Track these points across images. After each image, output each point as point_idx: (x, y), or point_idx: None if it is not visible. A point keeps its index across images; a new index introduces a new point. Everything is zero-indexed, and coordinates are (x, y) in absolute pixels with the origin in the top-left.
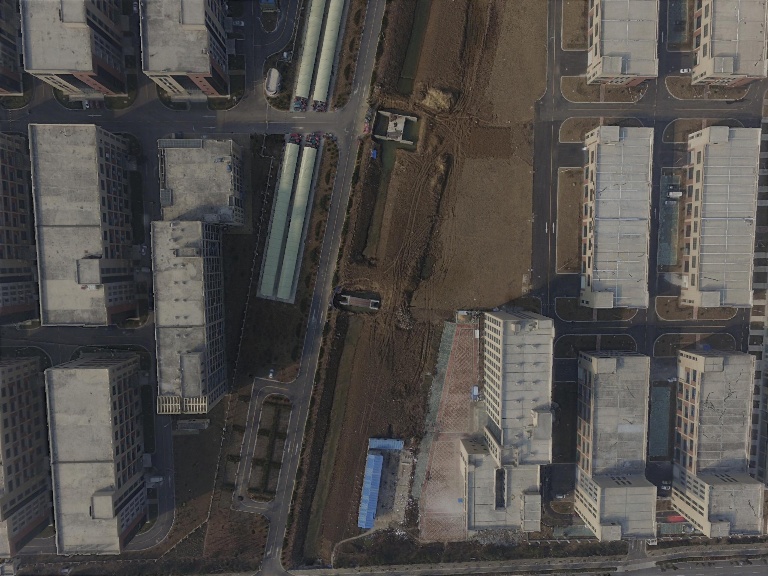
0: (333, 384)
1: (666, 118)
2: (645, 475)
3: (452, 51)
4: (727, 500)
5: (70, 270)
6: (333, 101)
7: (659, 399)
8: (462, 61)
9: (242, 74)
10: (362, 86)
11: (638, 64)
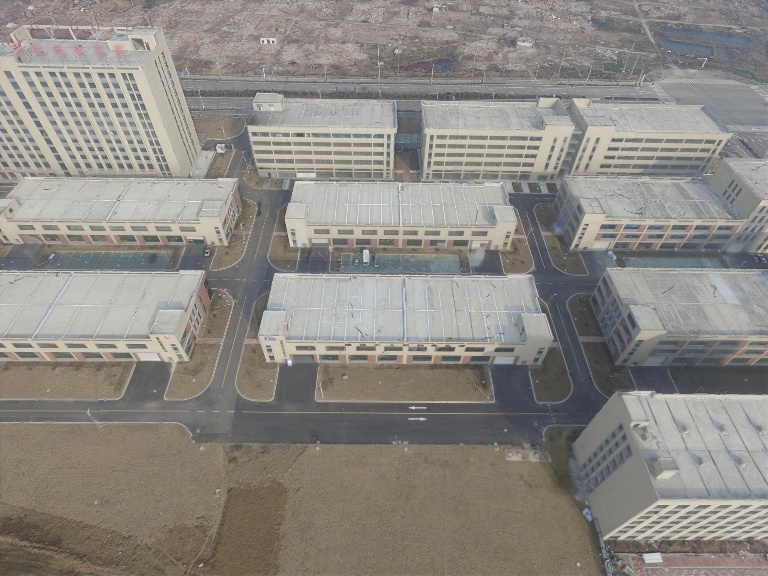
0: None
1: (264, 269)
2: None
3: None
4: (766, 187)
5: None
6: None
7: None
8: None
9: None
10: None
11: (179, 293)
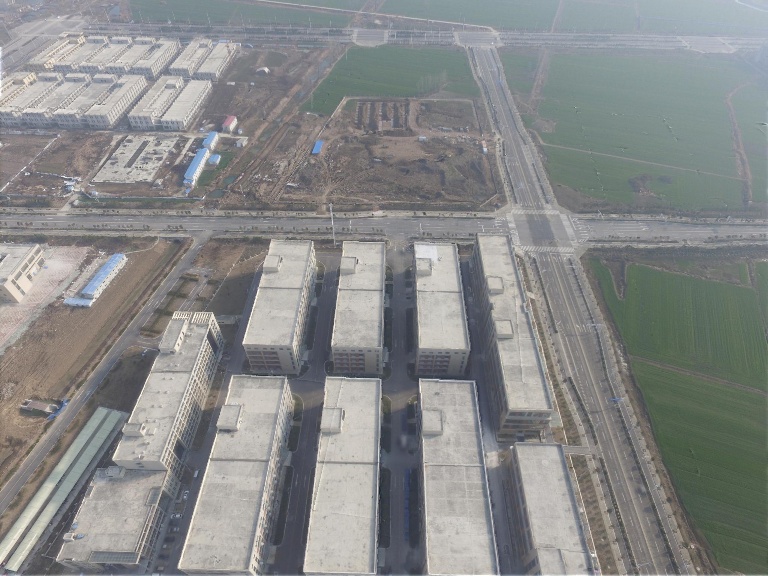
0: None
1: None
2: None
3: None
4: None
5: (252, 421)
6: None
7: None
8: None
9: None
10: None
11: None
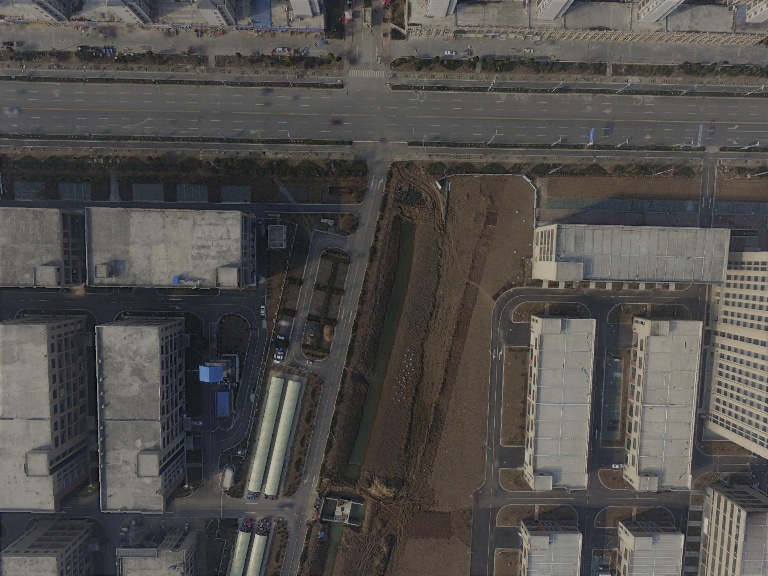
0: None
1: (598, 506)
2: None
3: (397, 445)
4: None
5: None
6: (284, 490)
7: None
8: (406, 453)
9: (199, 466)
10: (312, 476)
11: (569, 476)
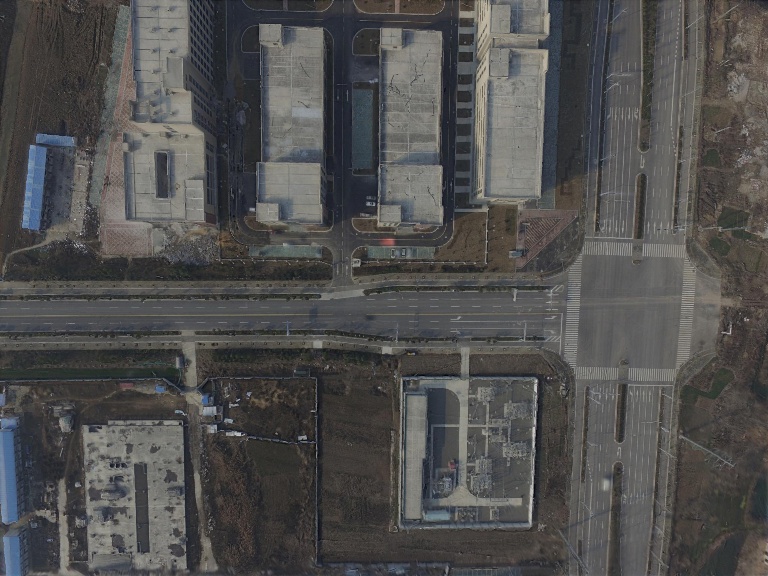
0: (1, 75)
1: None
2: (348, 190)
3: None
4: (403, 185)
5: None
6: None
7: (361, 103)
8: None
9: None
10: None
11: None
